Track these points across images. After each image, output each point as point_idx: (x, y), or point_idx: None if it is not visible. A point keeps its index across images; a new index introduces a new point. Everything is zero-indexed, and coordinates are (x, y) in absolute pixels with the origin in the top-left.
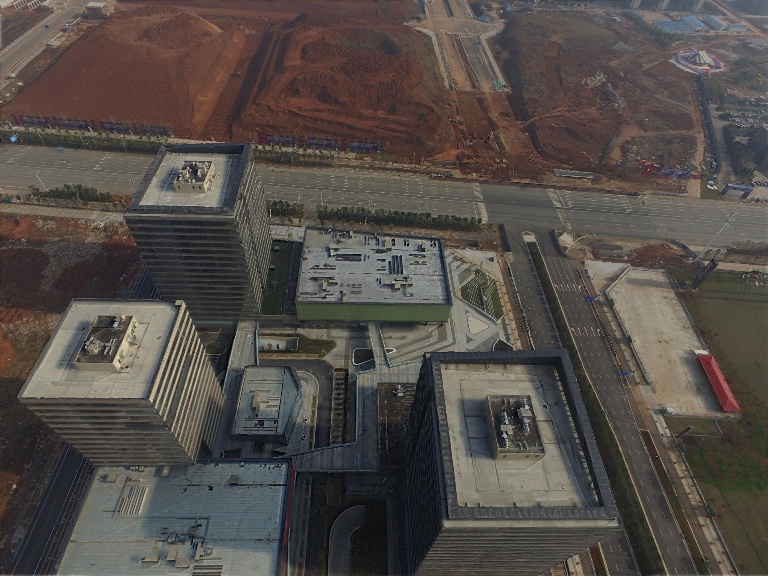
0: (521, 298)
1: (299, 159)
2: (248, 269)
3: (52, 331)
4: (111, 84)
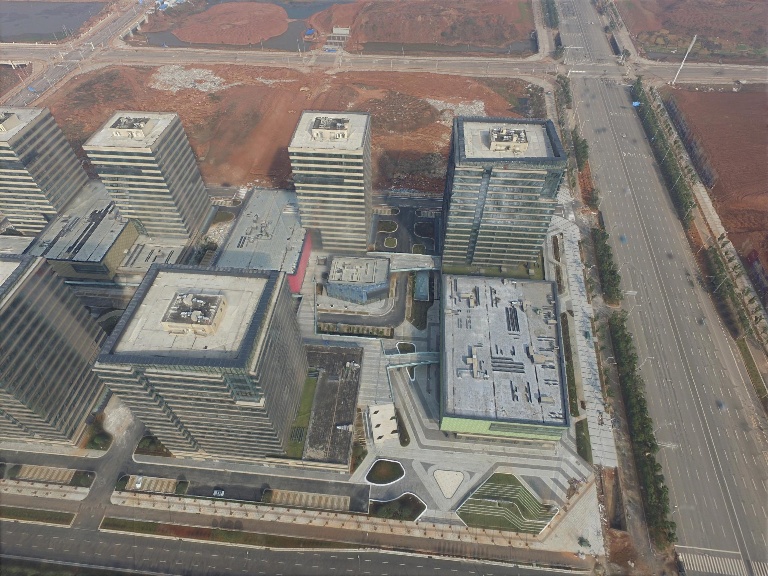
0: (504, 568)
1: (726, 296)
2: (449, 217)
3: (434, 170)
4: (766, 128)
